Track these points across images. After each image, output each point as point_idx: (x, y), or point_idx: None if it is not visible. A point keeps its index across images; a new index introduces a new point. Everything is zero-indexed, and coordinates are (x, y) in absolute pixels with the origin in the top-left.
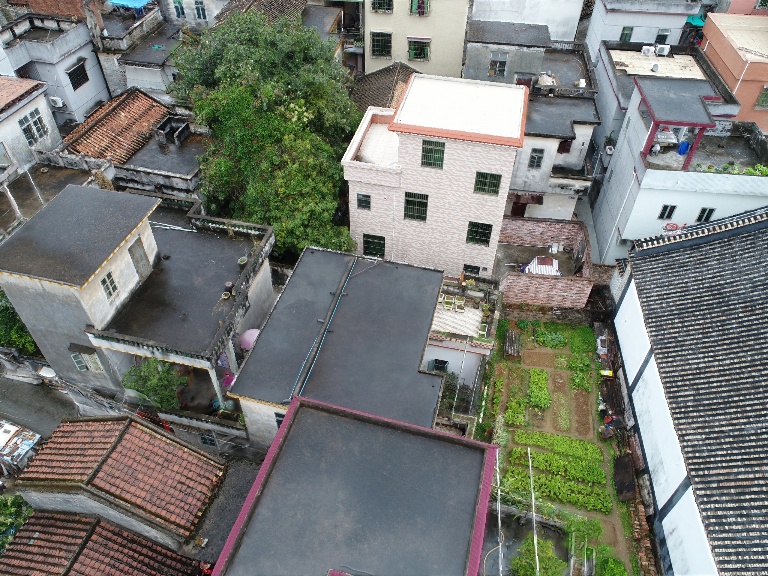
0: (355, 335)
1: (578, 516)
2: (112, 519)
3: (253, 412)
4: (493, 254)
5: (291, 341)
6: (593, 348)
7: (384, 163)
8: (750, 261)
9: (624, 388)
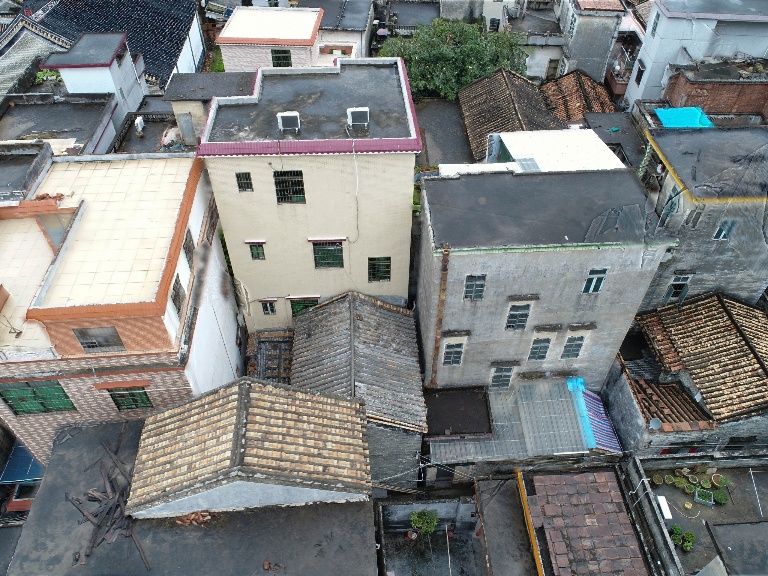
0: (329, 7)
1: None
2: None
3: None
4: None
5: (356, 4)
6: None
7: (331, 62)
8: None
9: None
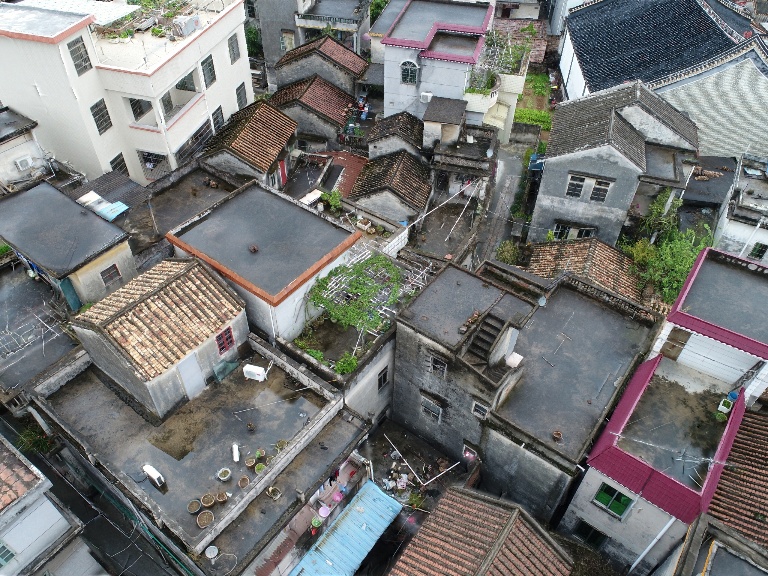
0: None
1: (526, 41)
2: (323, 75)
3: (376, 52)
4: (490, 25)
5: None
6: (548, 81)
7: None
8: (626, 7)
9: (563, 90)
